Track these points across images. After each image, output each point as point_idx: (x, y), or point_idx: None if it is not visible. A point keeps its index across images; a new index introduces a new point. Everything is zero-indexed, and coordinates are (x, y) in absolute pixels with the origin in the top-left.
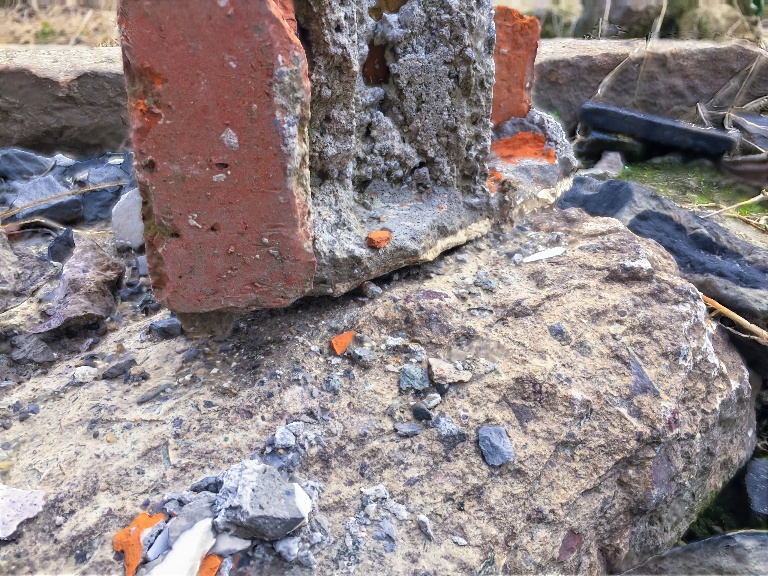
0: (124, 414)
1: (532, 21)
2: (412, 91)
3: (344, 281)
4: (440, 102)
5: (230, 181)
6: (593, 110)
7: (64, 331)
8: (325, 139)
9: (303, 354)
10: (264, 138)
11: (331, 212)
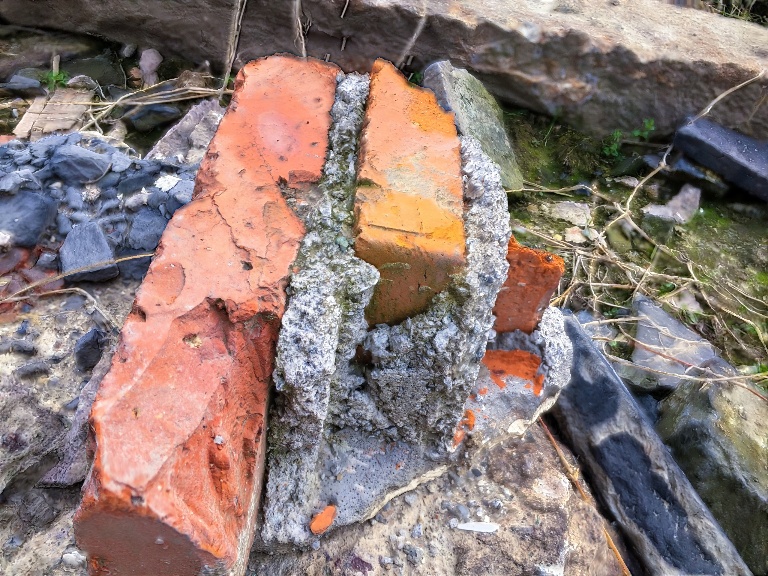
0: None
1: (557, 269)
2: (389, 389)
3: None
4: (415, 400)
5: None
6: (690, 138)
7: None
8: (293, 437)
9: None
10: None
11: (289, 482)
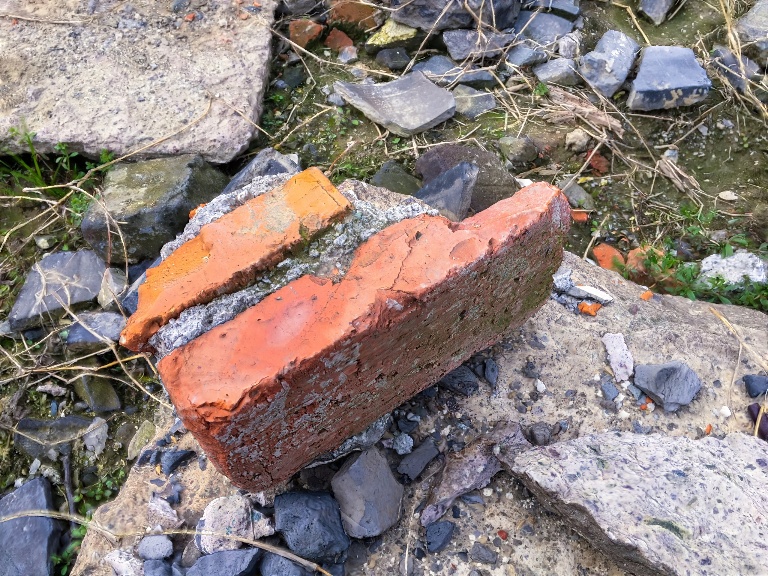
0: None
1: None
2: None
3: None
4: None
5: None
6: None
7: None
8: None
9: None
10: None
11: None
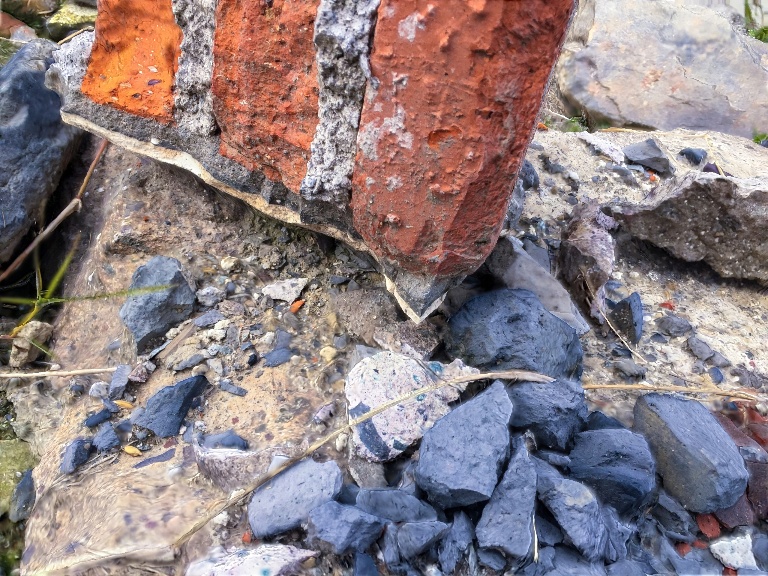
0: (550, 146)
1: None
2: None
3: None
4: None
5: None
6: None
7: None
8: None
9: None
10: None
11: None
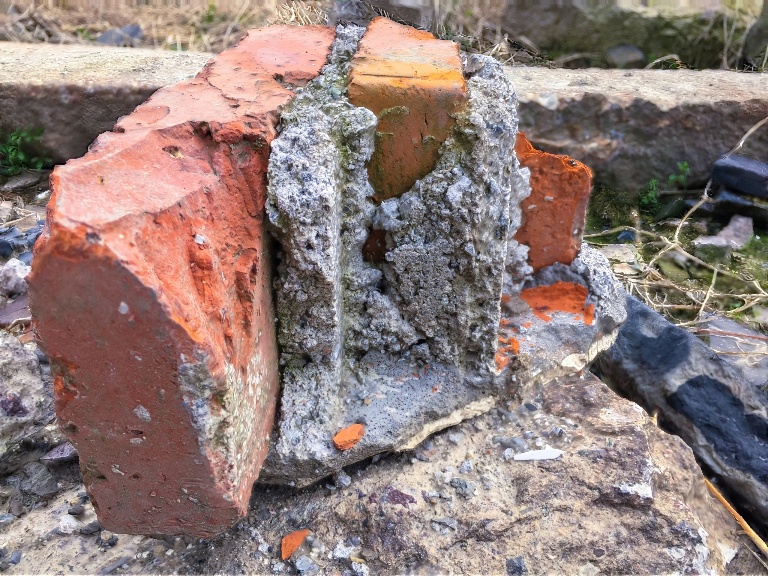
0: None
1: (583, 171)
2: (409, 277)
3: (306, 476)
4: (439, 289)
5: (146, 444)
6: (728, 168)
7: (74, 458)
8: (305, 331)
9: (248, 554)
10: (174, 415)
11: (308, 398)
